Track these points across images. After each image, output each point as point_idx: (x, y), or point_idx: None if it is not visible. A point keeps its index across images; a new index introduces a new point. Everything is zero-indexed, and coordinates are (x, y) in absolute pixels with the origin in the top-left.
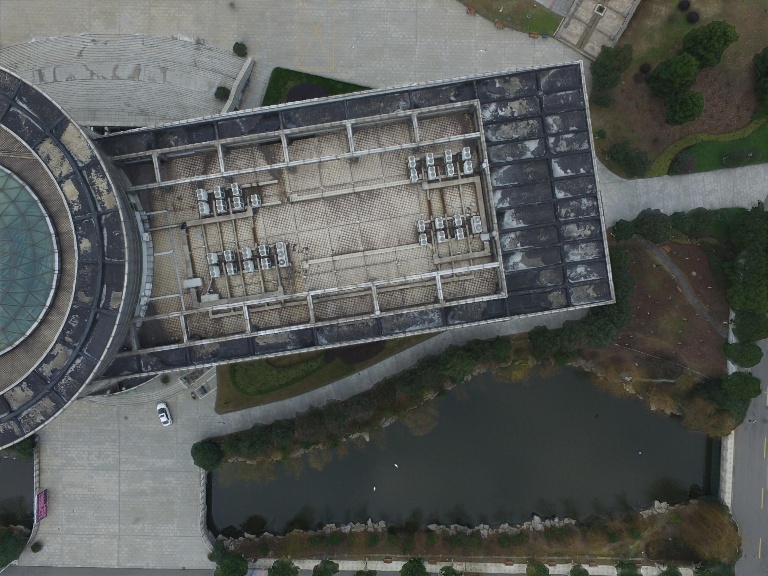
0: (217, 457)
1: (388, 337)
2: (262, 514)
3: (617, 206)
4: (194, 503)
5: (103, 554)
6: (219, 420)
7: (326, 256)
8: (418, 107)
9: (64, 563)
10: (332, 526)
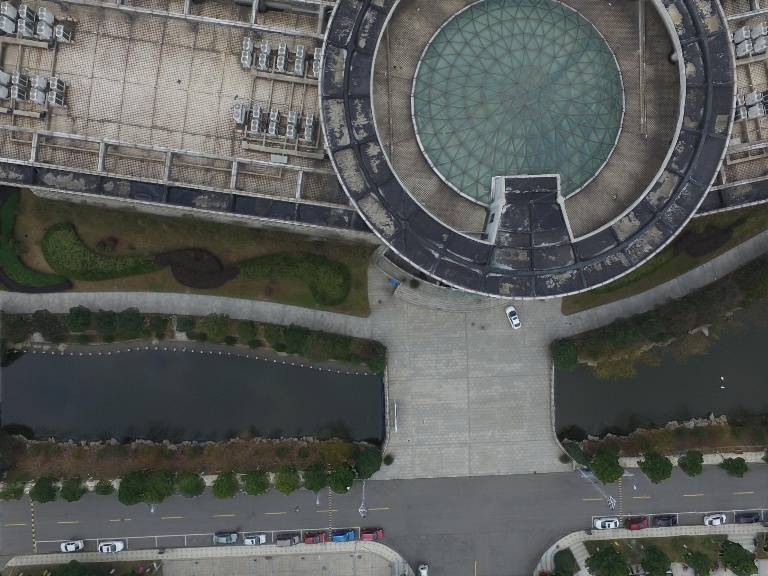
0: (577, 355)
1: None
2: (578, 424)
3: None
4: (543, 406)
5: (454, 463)
6: (566, 321)
7: None
8: None
9: (415, 475)
10: (674, 423)
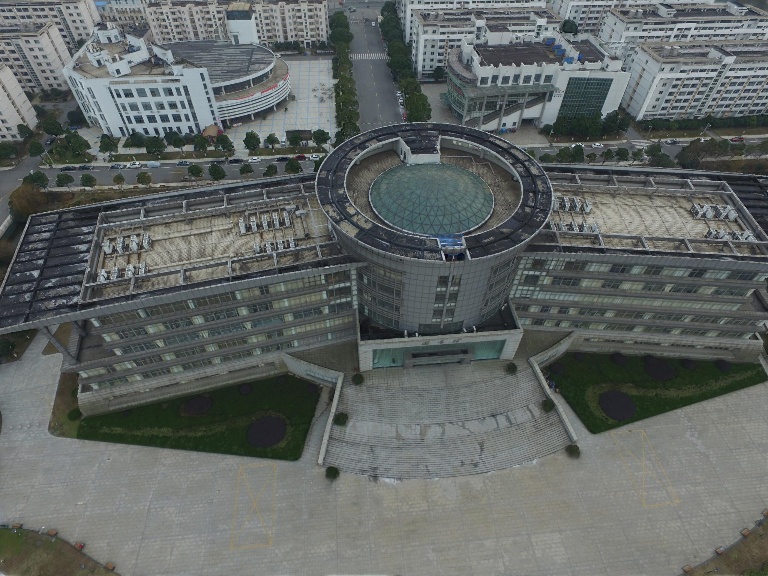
0: None
1: (179, 190)
2: None
3: (1, 377)
4: None
5: None
6: None
7: (216, 232)
8: (127, 299)
9: None
10: None
